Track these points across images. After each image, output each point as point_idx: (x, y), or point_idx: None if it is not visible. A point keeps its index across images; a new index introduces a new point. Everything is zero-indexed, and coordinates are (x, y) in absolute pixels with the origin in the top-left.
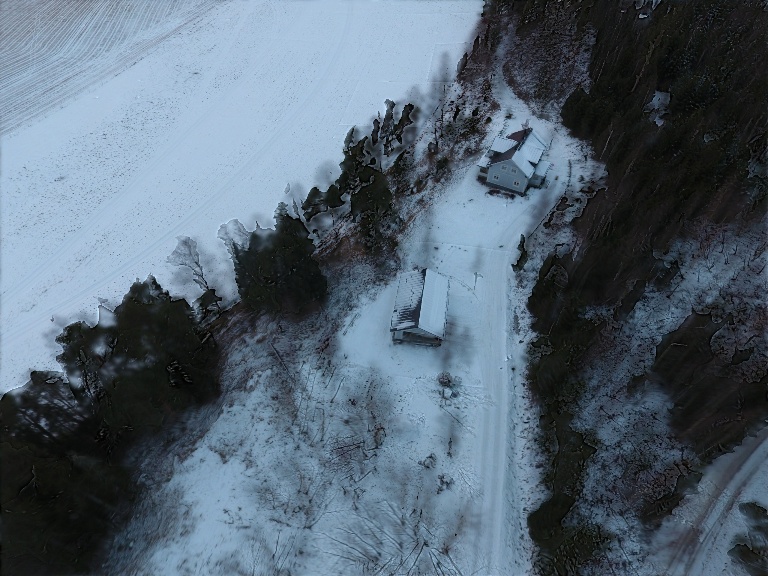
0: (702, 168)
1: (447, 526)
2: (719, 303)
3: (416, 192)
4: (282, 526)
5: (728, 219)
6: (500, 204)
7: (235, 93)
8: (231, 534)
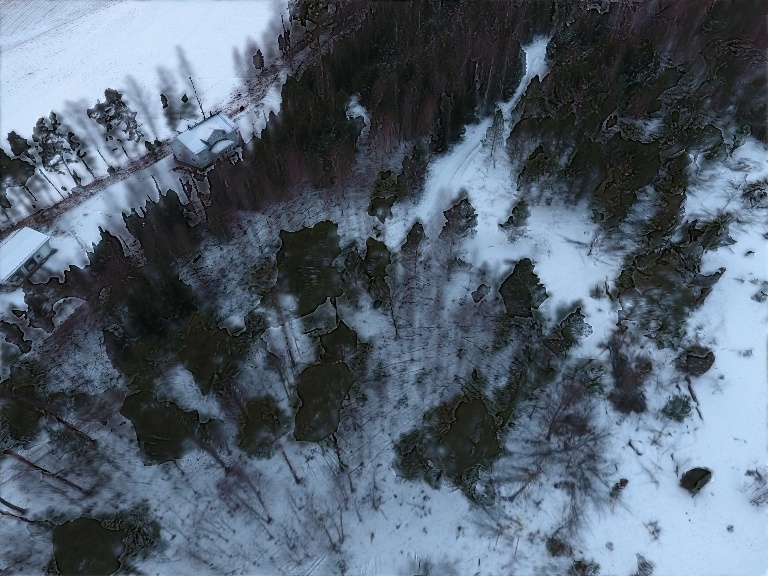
0: (278, 137)
1: None
2: (254, 253)
3: None
4: None
5: (323, 185)
6: (175, 178)
7: (54, 90)
8: None
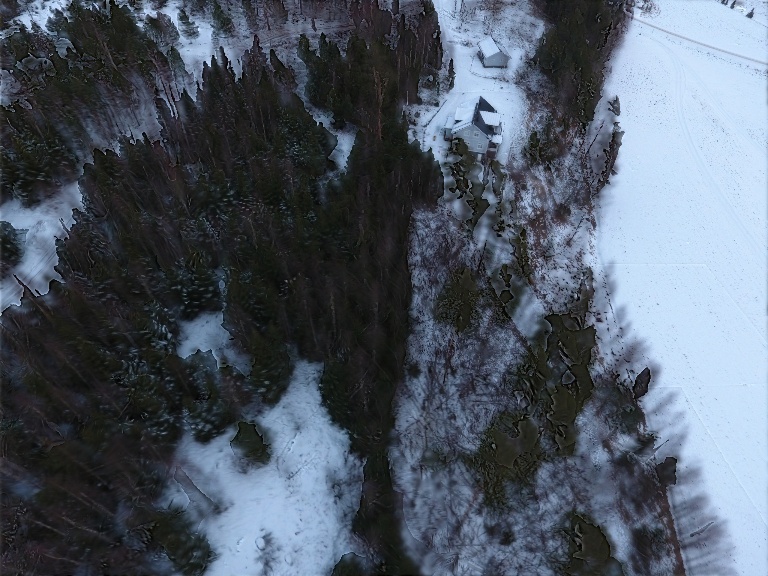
0: None
1: (455, 22)
2: None
3: (545, 163)
4: (502, 17)
5: None
6: None
7: None
8: (515, 13)
